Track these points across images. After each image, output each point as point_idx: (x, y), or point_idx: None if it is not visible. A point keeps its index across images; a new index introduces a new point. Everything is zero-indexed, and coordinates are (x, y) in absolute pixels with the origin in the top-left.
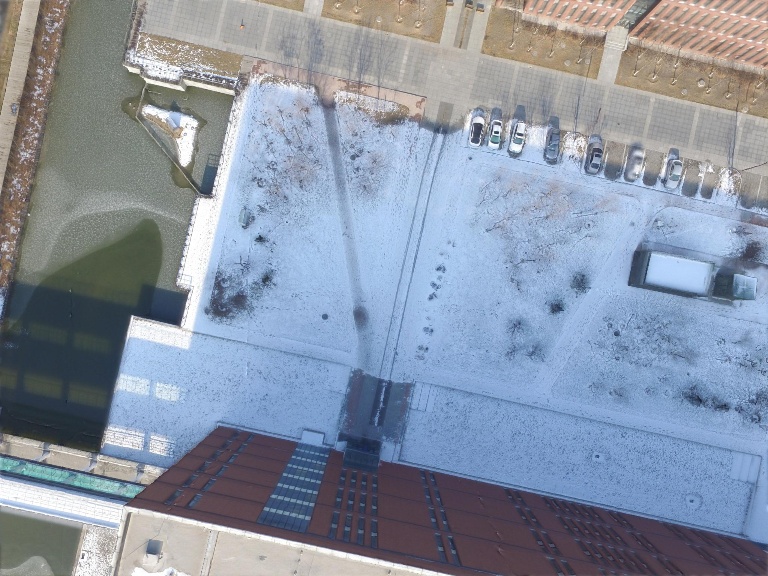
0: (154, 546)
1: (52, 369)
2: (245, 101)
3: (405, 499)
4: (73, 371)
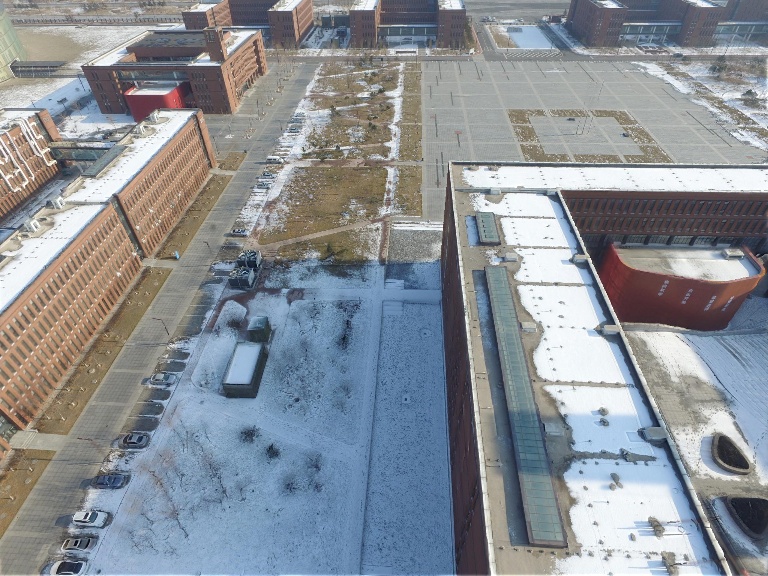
0: None
1: None
2: None
3: (468, 569)
4: None
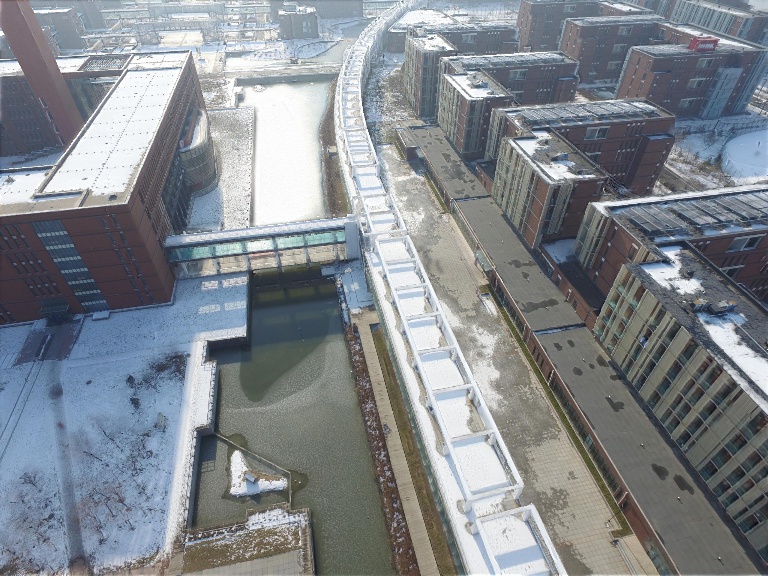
0: (113, 199)
1: (300, 301)
2: (174, 525)
3: (2, 280)
4: (286, 303)
